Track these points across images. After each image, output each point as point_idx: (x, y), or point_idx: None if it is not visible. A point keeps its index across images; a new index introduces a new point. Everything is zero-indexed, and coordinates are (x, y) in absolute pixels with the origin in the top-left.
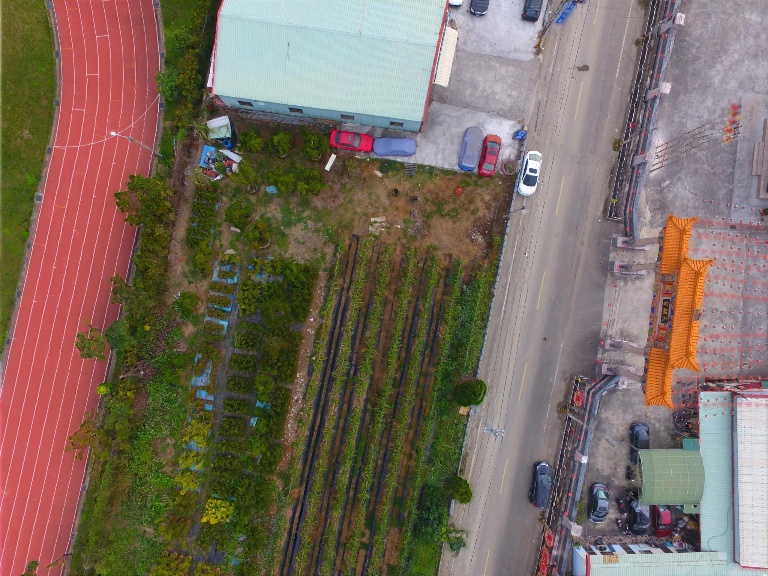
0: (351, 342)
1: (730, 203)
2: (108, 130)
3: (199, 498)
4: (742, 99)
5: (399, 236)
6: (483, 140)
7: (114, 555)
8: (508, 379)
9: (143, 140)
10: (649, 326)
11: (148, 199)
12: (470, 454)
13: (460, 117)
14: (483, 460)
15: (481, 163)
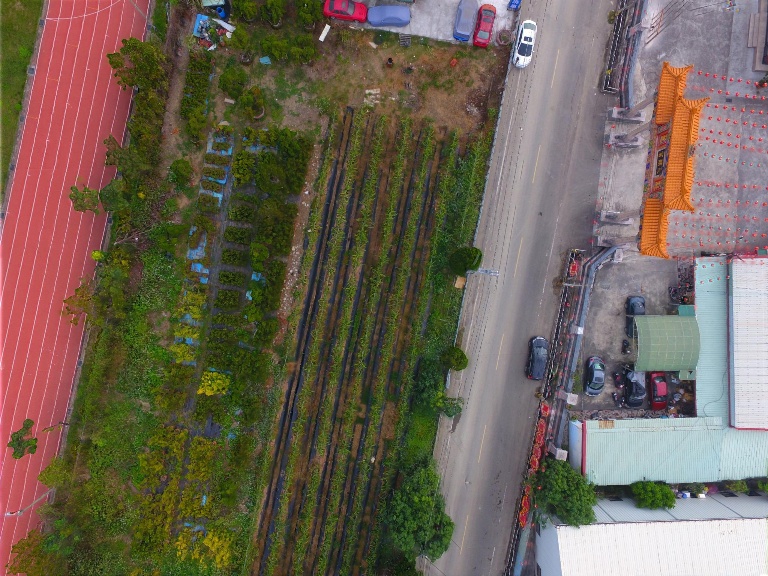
0: (346, 214)
1: (726, 76)
2: (100, 2)
3: (195, 372)
4: None
5: (394, 108)
6: (478, 11)
7: (110, 426)
8: (504, 254)
9: (136, 12)
10: (644, 183)
11: (141, 58)
12: (466, 329)
13: None
14: (479, 335)
15: (476, 32)
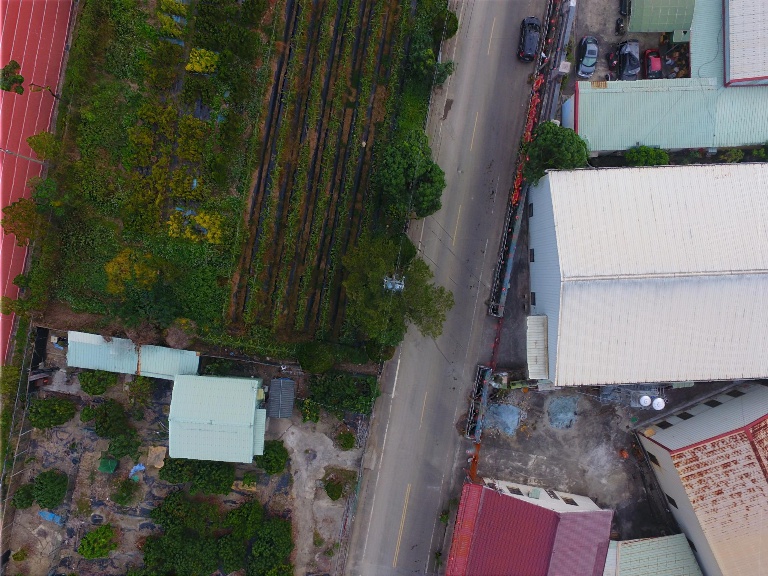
0: None
1: None
2: None
3: (183, 52)
4: None
5: None
6: None
7: (99, 102)
8: None
9: None
10: None
11: None
12: (457, 13)
13: None
14: (470, 18)
15: None
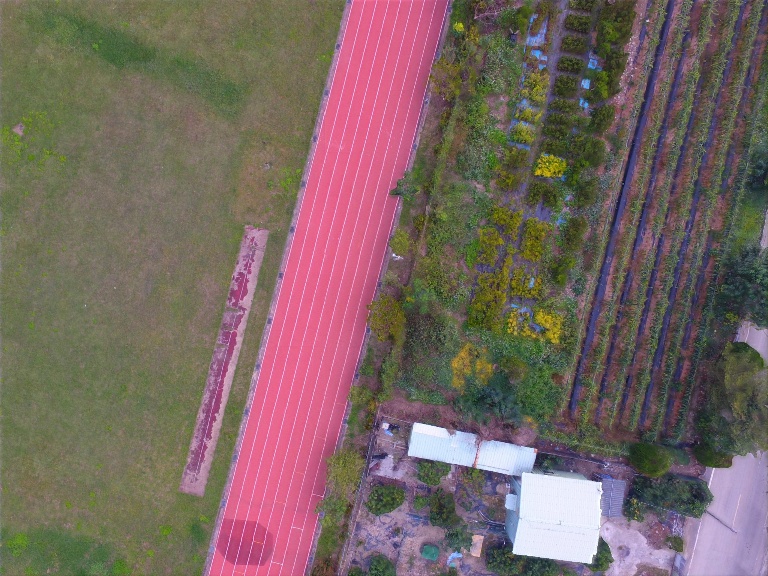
0: None
1: None
2: None
3: (529, 156)
4: None
5: None
6: None
7: (451, 202)
8: None
9: None
10: None
11: None
12: None
13: None
14: None
15: None
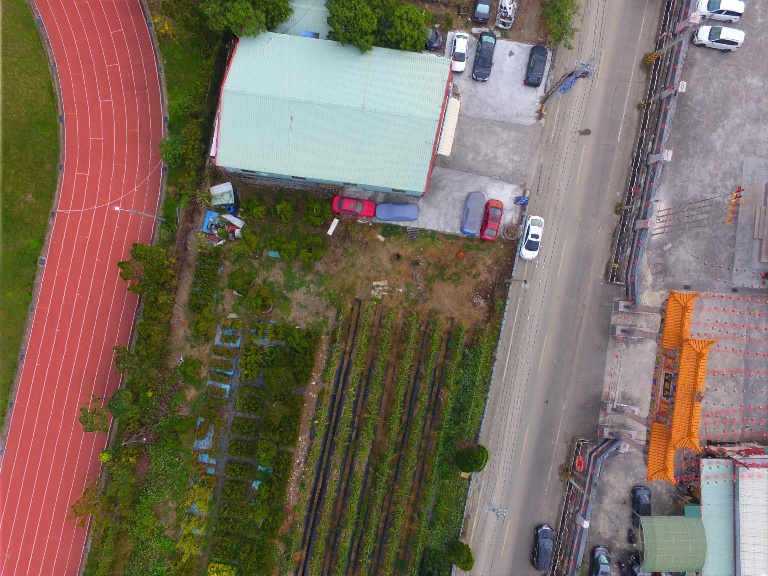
0: (353, 406)
1: (732, 266)
2: (111, 194)
3: (201, 561)
4: (744, 163)
5: (401, 300)
6: (485, 204)
7: None
8: (510, 442)
9: (146, 204)
10: (651, 397)
11: (151, 269)
12: (472, 516)
13: (462, 181)
14: (485, 523)
15: (483, 228)
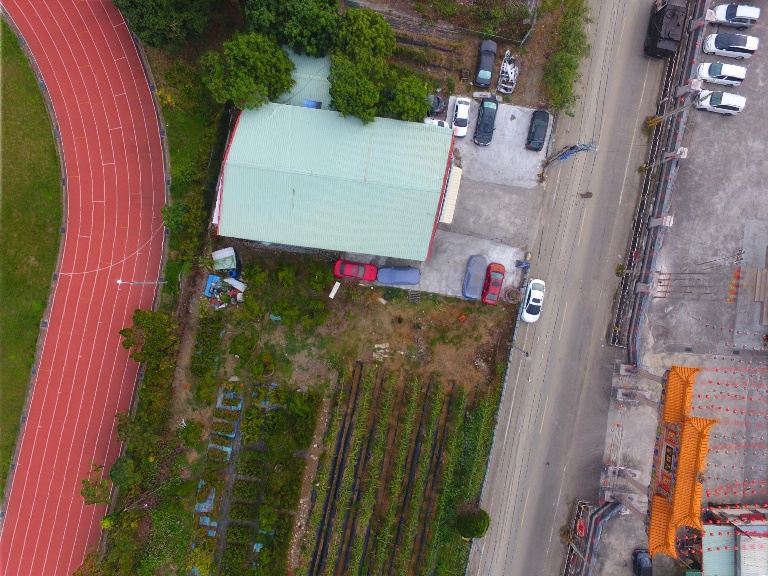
0: (354, 469)
1: (733, 329)
2: (114, 257)
3: None
4: (745, 226)
5: (403, 362)
6: (486, 268)
7: None
8: (511, 503)
9: (148, 266)
10: (652, 468)
11: (153, 338)
12: None
13: (464, 245)
14: None
15: (484, 293)
